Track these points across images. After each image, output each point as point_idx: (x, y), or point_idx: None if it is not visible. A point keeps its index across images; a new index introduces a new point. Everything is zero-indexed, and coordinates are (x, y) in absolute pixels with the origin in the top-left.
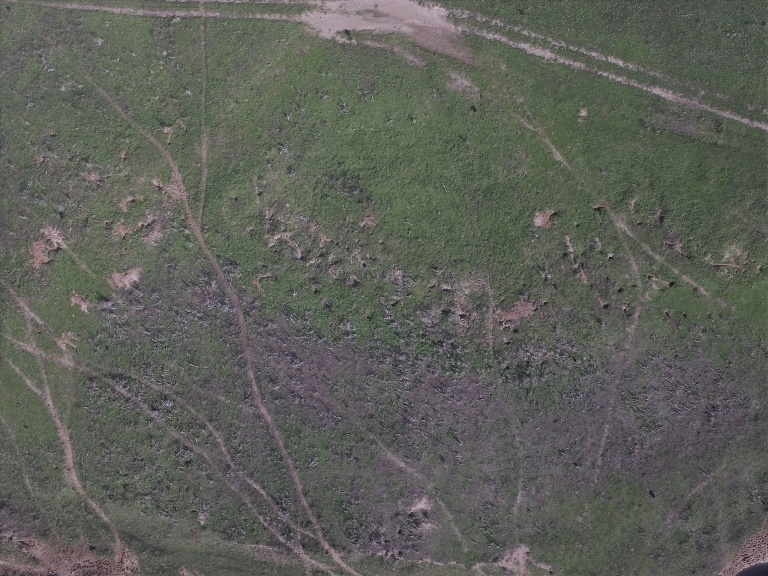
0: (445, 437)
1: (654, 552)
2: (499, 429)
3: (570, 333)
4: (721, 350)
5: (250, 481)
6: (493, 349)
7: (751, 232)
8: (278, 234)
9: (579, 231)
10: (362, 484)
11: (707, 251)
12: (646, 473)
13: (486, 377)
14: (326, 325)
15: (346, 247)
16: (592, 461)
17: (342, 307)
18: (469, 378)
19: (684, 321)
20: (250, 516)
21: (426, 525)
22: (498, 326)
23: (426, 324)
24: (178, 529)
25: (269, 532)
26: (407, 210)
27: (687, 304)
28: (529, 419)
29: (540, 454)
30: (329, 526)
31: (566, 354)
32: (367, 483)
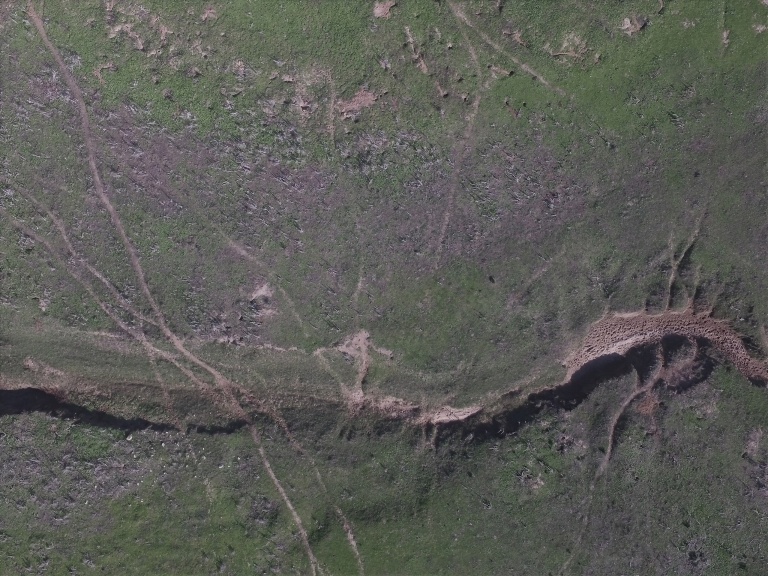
0: (286, 226)
1: (494, 337)
2: (340, 217)
3: (410, 122)
4: (561, 139)
5: (92, 270)
6: (334, 139)
7: (590, 21)
8: (119, 25)
9: (419, 22)
10: (204, 272)
11: (545, 40)
12: (486, 259)
13: (327, 166)
14: (167, 116)
15: (187, 39)
16: (433, 248)
17: (183, 97)
18: (310, 167)
19: (523, 110)
20: (92, 303)
21: (267, 311)
22: (339, 116)
23: (267, 115)
24: (21, 317)
25: (111, 319)
26: (249, 4)
27: (526, 93)
28: (370, 207)
29: (381, 242)
30: (171, 313)
31: (407, 143)
32: (209, 271)
